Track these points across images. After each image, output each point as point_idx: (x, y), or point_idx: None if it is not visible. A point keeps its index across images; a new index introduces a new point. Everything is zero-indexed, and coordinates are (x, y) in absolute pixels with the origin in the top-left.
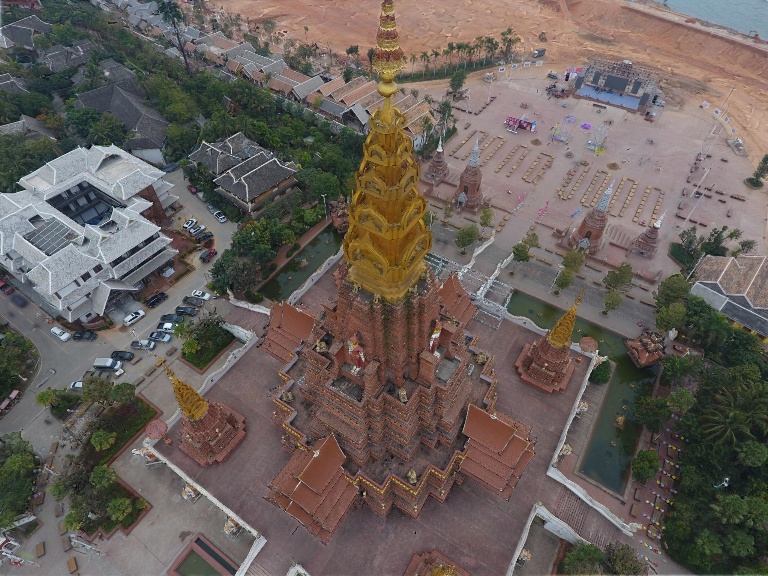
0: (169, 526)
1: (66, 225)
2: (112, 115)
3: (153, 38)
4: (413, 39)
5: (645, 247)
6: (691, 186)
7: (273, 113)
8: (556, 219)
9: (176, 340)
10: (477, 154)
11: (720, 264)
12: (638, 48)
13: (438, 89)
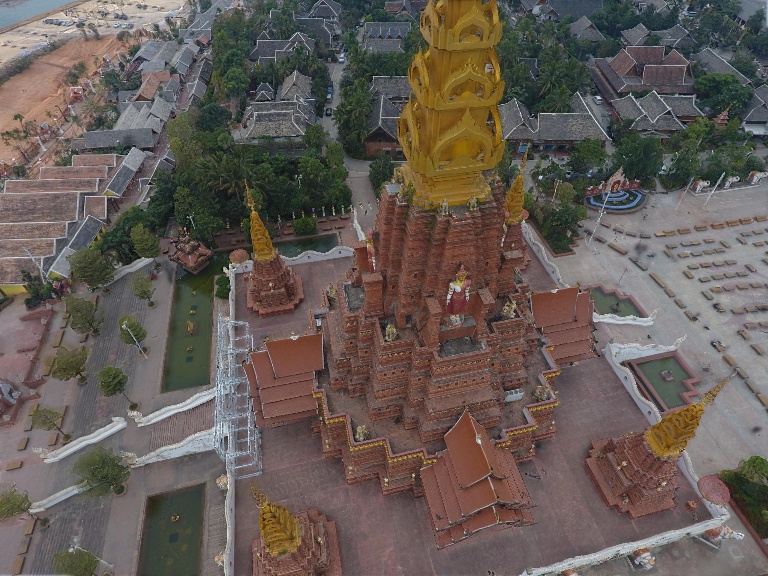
0: (691, 445)
1: None
2: None
3: None
4: None
5: None
6: None
7: None
8: None
9: None
10: None
11: (3, 265)
12: None
13: None
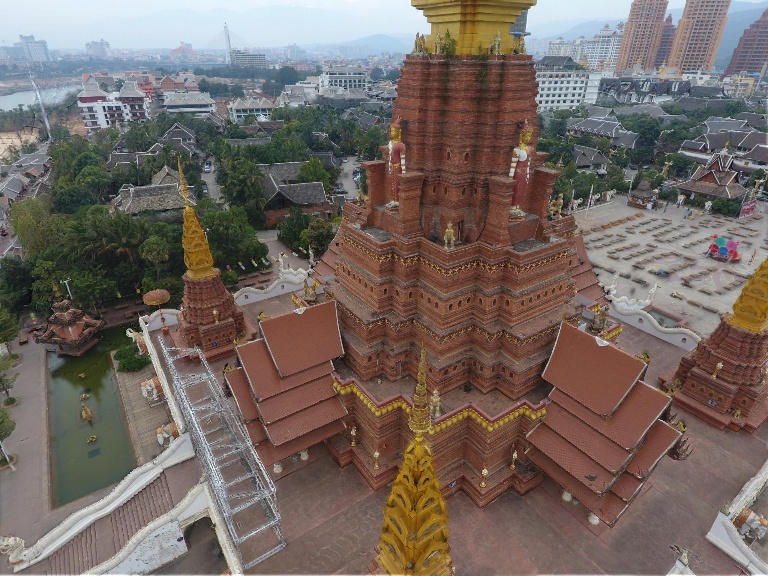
0: None
1: None
2: None
3: None
4: None
5: None
6: None
7: None
8: None
9: None
10: None
11: None
12: None
13: None
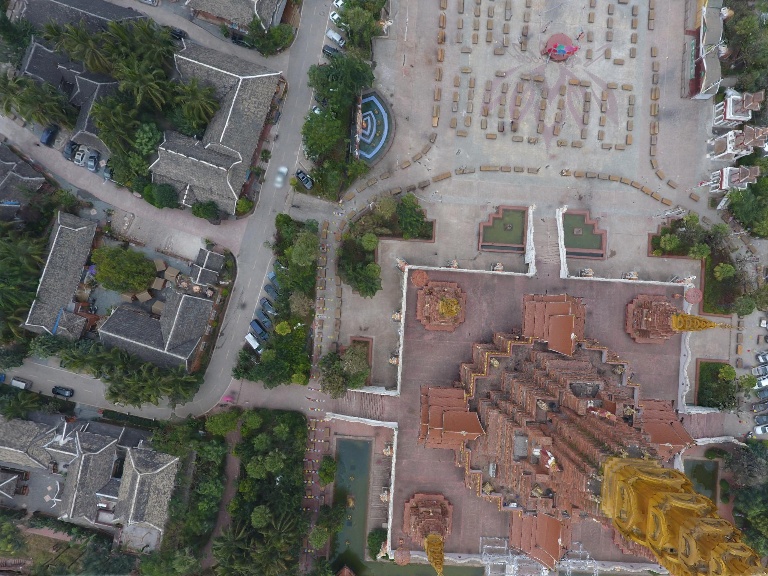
0: (627, 253)
1: None
2: None
3: None
4: None
5: None
6: None
7: None
8: None
9: None
10: None
11: None
12: None
13: None
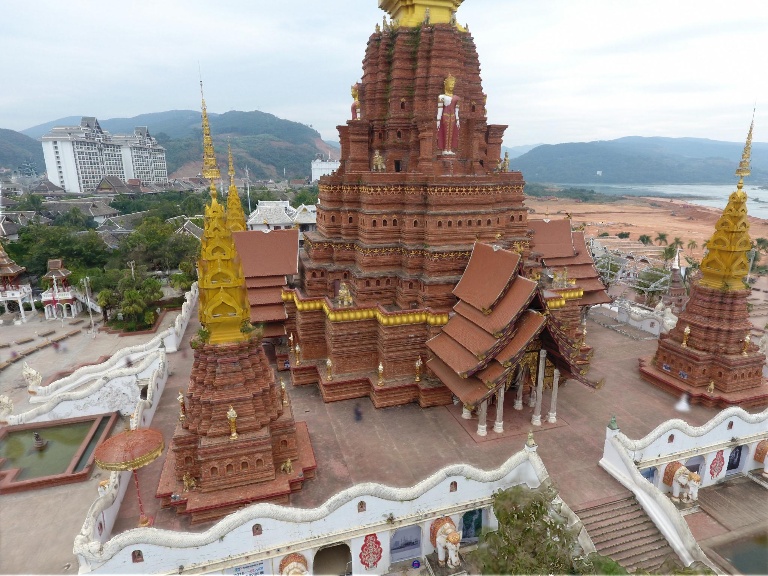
0: None
1: None
2: None
3: None
4: None
5: None
6: None
7: None
8: None
9: None
10: None
11: None
12: None
13: None
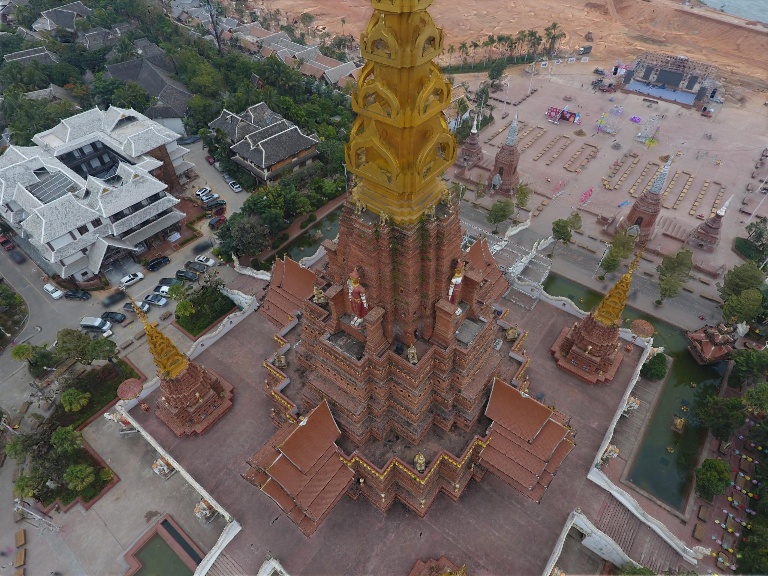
0: (135, 503)
1: (70, 178)
2: (136, 83)
3: (192, 27)
4: (452, 37)
5: (705, 238)
6: (756, 182)
7: (301, 93)
8: (601, 208)
9: (172, 305)
10: (515, 131)
11: None
12: (693, 49)
13: (476, 81)
